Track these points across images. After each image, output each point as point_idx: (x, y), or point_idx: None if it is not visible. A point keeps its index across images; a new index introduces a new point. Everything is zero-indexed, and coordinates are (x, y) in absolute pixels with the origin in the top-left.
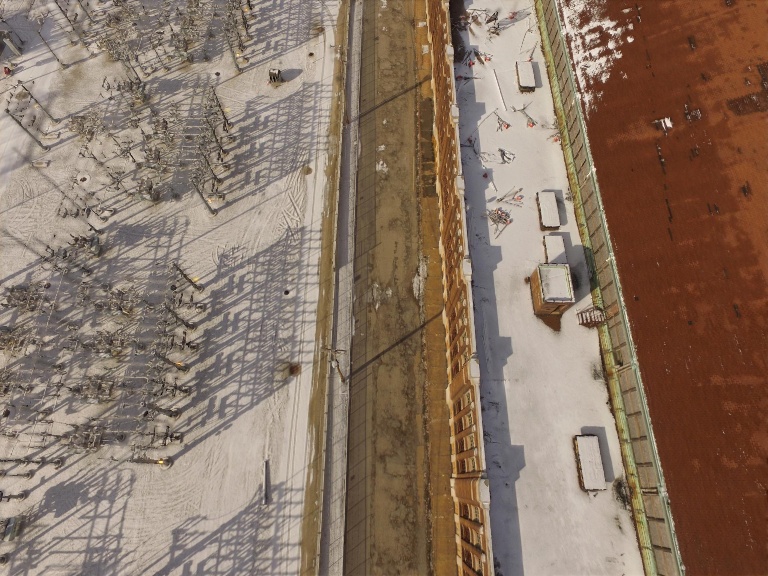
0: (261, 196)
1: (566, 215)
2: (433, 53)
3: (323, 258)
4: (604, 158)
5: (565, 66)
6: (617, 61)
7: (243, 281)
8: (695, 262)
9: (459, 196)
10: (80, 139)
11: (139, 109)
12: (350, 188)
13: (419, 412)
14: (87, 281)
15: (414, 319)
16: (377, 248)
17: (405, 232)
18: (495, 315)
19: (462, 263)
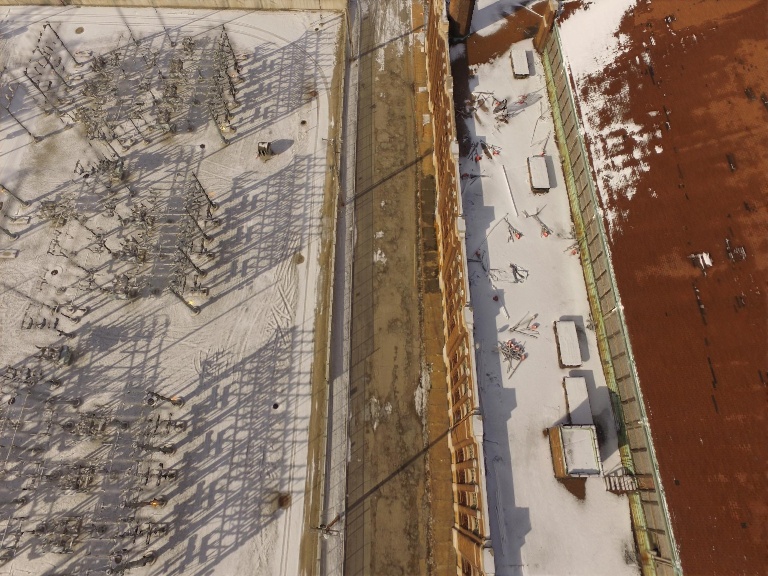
0: (248, 290)
1: (588, 348)
2: (435, 127)
3: (316, 364)
4: (633, 295)
5: (583, 170)
6: (644, 175)
7: (228, 393)
8: (746, 445)
9: (467, 330)
10: (52, 224)
11: (117, 188)
12: (345, 282)
13: (423, 556)
14: (56, 395)
15: (416, 441)
16: (375, 355)
17: (406, 335)
18: (510, 479)
19: (472, 420)
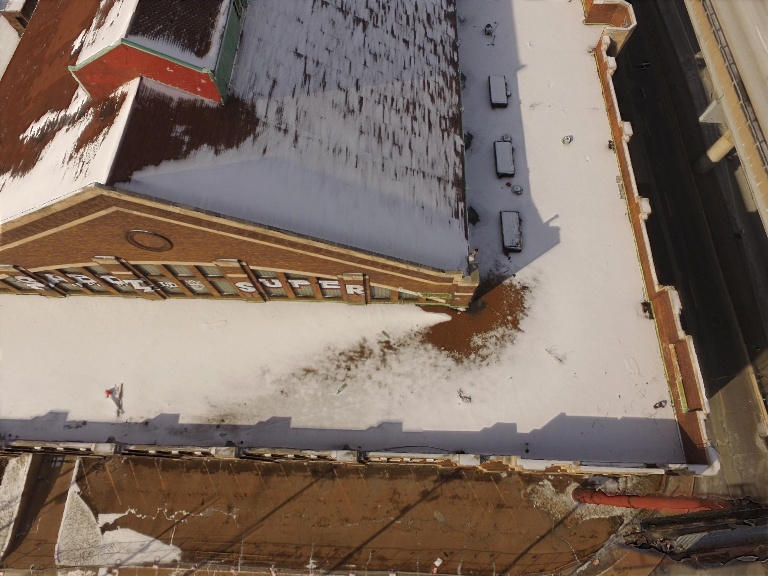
0: None
1: None
2: None
3: None
4: None
5: None
6: None
7: None
8: None
9: None
10: None
11: None
12: None
13: None
14: None
15: None
16: None
17: None
18: None
19: None
